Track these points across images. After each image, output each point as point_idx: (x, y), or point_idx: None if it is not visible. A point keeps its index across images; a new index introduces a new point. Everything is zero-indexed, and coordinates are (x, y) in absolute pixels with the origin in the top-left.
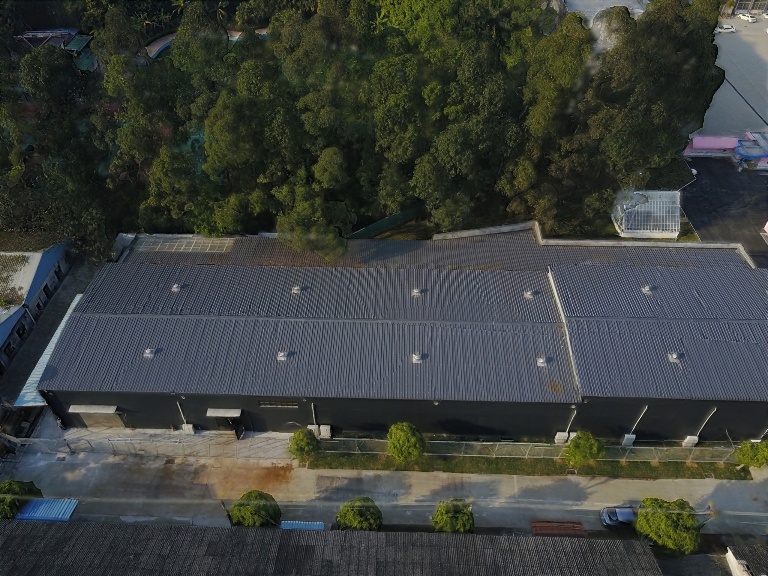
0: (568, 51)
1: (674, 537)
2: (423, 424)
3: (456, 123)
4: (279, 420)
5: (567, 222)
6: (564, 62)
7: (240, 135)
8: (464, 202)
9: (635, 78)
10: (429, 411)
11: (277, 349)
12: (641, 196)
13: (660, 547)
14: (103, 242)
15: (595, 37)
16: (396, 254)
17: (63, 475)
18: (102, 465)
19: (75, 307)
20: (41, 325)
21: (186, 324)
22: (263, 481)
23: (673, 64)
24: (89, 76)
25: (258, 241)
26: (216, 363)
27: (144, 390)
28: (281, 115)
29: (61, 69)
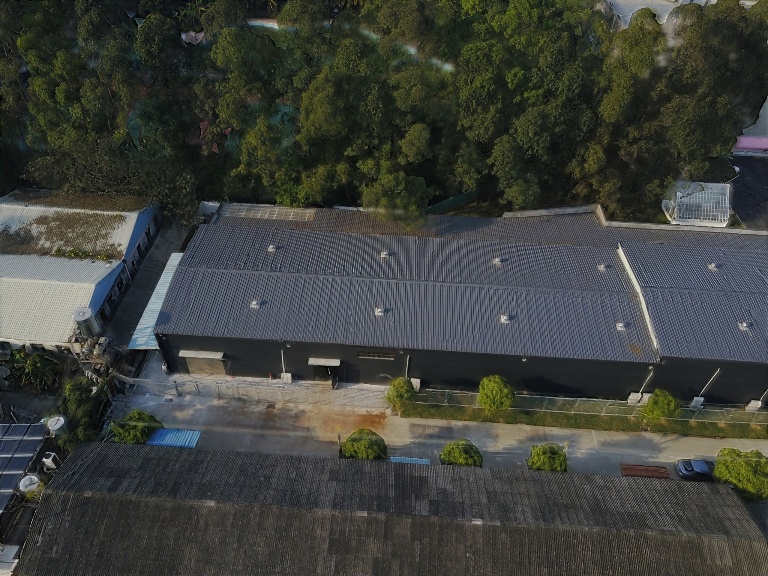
0: (646, 43)
1: (753, 481)
2: (507, 380)
3: (535, 107)
4: (372, 372)
5: (620, 209)
6: (642, 53)
7: (339, 108)
8: (534, 183)
9: (703, 72)
10: (515, 367)
11: (374, 305)
12: (698, 185)
13: (739, 490)
14: (194, 206)
15: (669, 31)
16: (470, 229)
17: (172, 414)
18: (208, 407)
19: (180, 261)
20: (139, 280)
21: (287, 280)
22: (360, 426)
23: (737, 61)
24: (194, 48)
25: (338, 212)
26: (318, 316)
27: (254, 337)
28: (376, 91)
29: (172, 39)
